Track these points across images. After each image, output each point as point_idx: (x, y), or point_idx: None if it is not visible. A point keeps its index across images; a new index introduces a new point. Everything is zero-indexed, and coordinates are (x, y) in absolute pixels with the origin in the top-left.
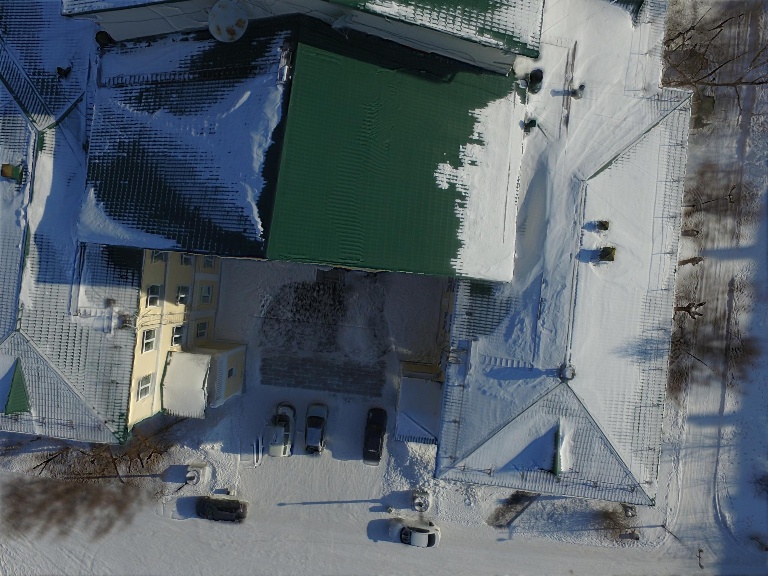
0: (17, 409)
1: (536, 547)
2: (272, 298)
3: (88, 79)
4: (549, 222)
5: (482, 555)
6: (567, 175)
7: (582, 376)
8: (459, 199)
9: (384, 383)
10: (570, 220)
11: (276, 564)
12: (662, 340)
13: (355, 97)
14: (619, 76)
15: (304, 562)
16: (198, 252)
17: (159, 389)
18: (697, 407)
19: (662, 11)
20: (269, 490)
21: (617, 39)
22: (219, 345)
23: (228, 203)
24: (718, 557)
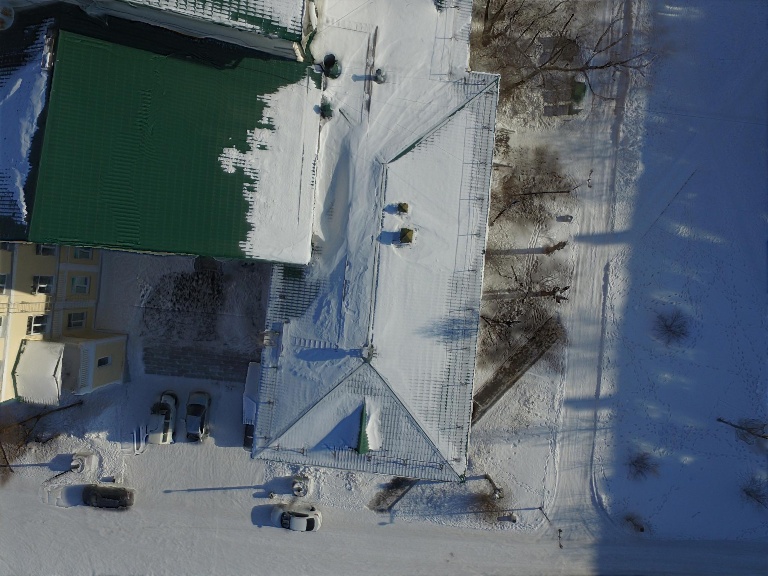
0: None
1: (417, 530)
2: (152, 288)
3: None
4: (351, 205)
5: (364, 539)
6: (369, 159)
7: (385, 356)
8: (248, 183)
9: None
10: (371, 203)
11: (163, 550)
12: (470, 320)
13: (131, 83)
14: (424, 60)
15: (190, 548)
16: None
17: (11, 377)
18: (574, 391)
19: None
20: (155, 477)
21: (420, 24)
22: (92, 334)
23: (2, 188)
24: (595, 538)
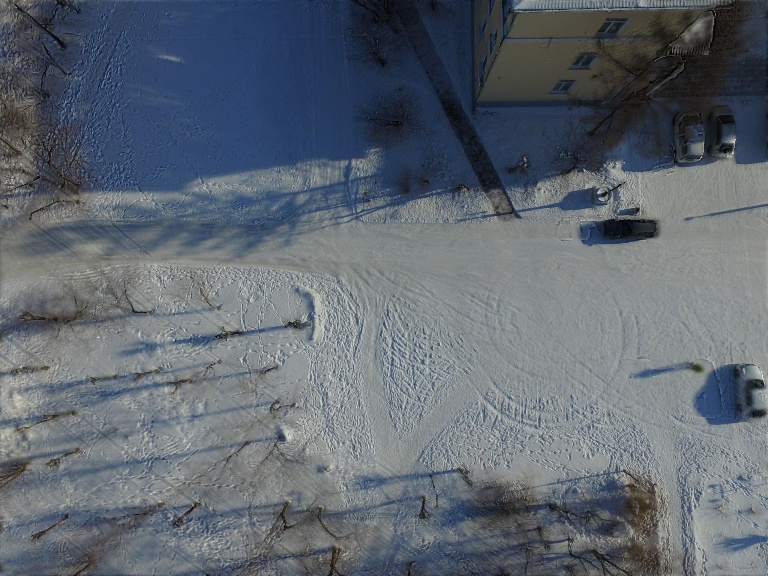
0: None
1: None
2: None
3: None
4: None
5: None
6: None
7: None
8: None
9: None
10: None
11: (692, 280)
12: None
13: None
14: None
15: (720, 274)
16: None
17: None
18: None
19: None
20: (674, 205)
21: None
22: None
23: None
24: None
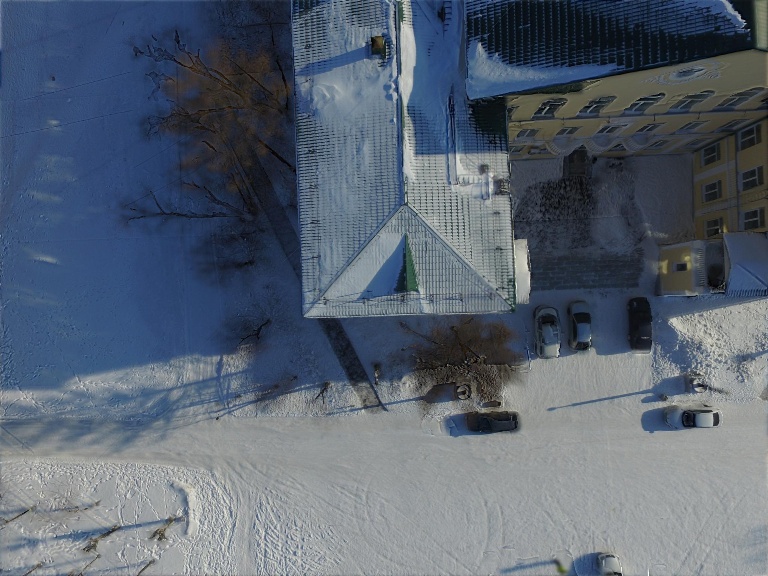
0: (411, 286)
1: None
2: (519, 201)
3: None
4: None
5: (761, 430)
6: None
7: None
8: None
9: (642, 271)
10: None
11: (554, 469)
12: None
13: None
14: None
15: (583, 463)
16: (652, 66)
17: None
18: None
19: None
20: (537, 396)
21: None
22: None
23: (685, 9)
24: None
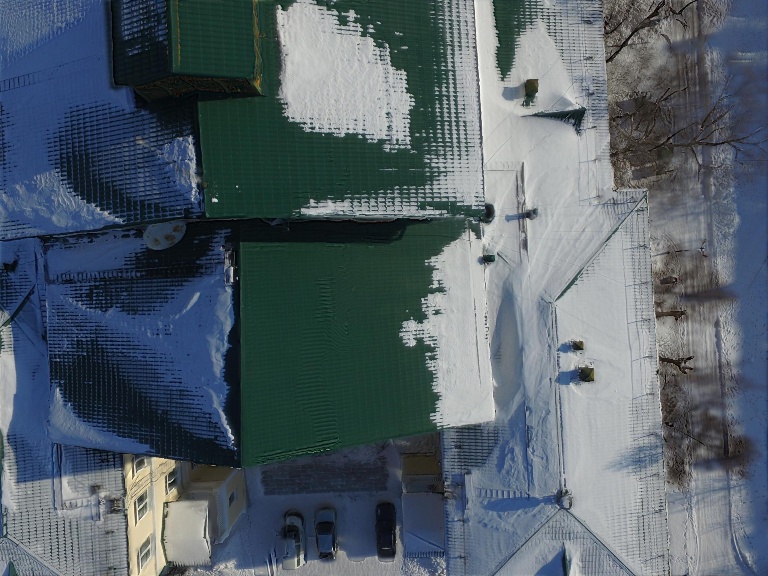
0: None
1: None
2: None
3: (36, 272)
4: (523, 349)
5: None
6: (534, 298)
7: (580, 498)
8: (429, 352)
9: (387, 477)
10: (544, 344)
11: None
12: (654, 445)
13: (307, 276)
14: (571, 188)
15: None
16: None
17: (160, 545)
18: (702, 452)
19: (605, 113)
20: None
21: (564, 151)
22: (216, 472)
23: (195, 408)
24: None
